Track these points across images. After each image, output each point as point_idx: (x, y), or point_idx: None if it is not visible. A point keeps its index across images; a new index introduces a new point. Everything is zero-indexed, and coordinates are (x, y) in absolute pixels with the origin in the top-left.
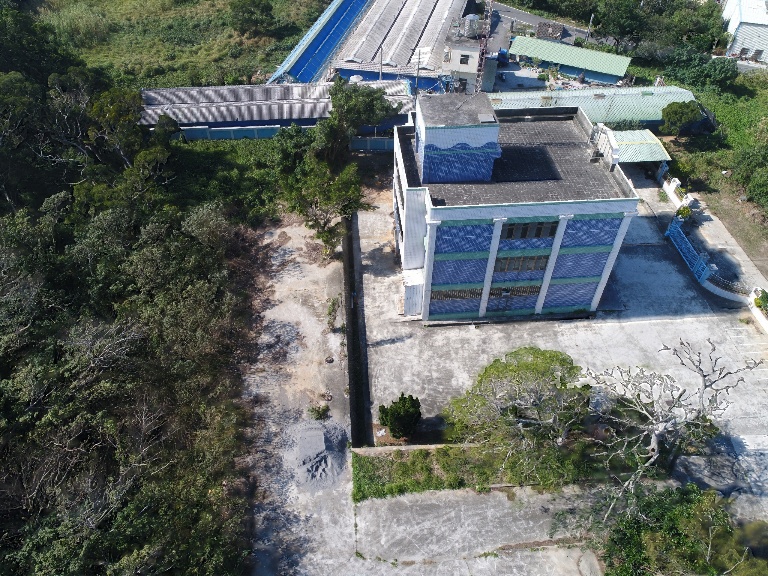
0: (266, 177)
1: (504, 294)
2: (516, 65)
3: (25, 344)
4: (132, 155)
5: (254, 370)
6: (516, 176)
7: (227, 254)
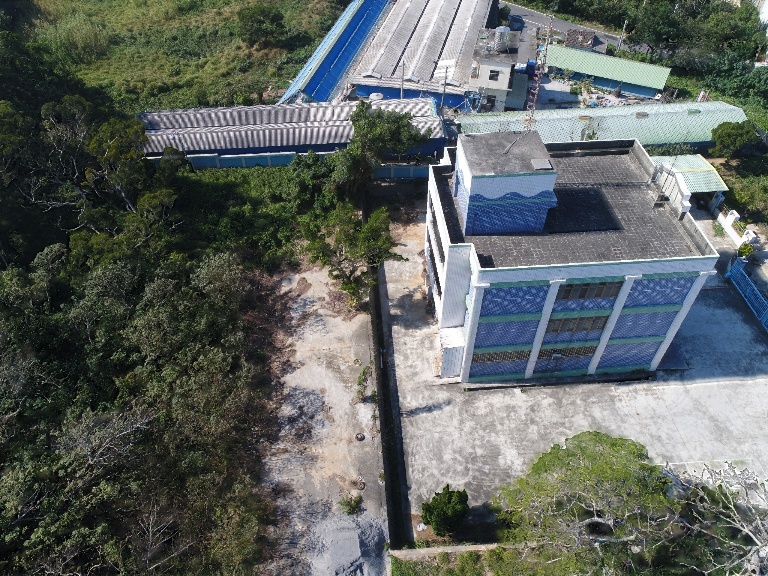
0: (282, 212)
1: (555, 356)
2: (545, 77)
3: (13, 434)
4: (135, 193)
5: (275, 451)
6: (571, 225)
7: (241, 306)
